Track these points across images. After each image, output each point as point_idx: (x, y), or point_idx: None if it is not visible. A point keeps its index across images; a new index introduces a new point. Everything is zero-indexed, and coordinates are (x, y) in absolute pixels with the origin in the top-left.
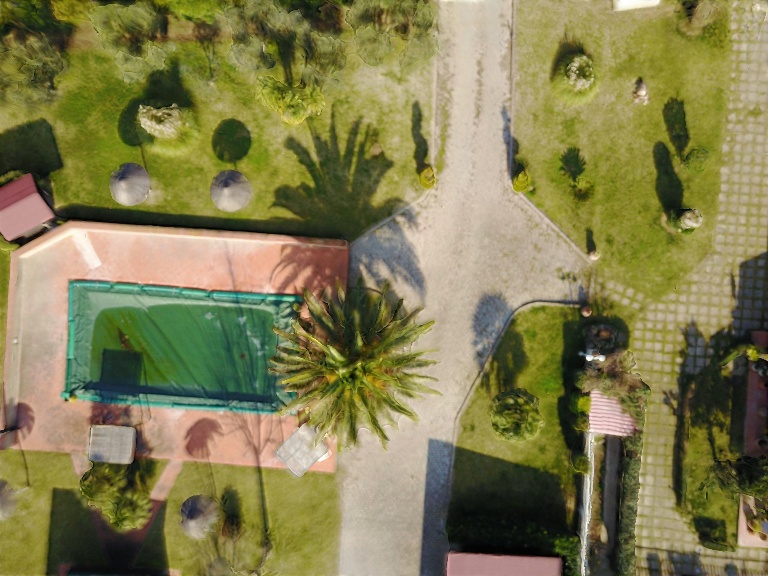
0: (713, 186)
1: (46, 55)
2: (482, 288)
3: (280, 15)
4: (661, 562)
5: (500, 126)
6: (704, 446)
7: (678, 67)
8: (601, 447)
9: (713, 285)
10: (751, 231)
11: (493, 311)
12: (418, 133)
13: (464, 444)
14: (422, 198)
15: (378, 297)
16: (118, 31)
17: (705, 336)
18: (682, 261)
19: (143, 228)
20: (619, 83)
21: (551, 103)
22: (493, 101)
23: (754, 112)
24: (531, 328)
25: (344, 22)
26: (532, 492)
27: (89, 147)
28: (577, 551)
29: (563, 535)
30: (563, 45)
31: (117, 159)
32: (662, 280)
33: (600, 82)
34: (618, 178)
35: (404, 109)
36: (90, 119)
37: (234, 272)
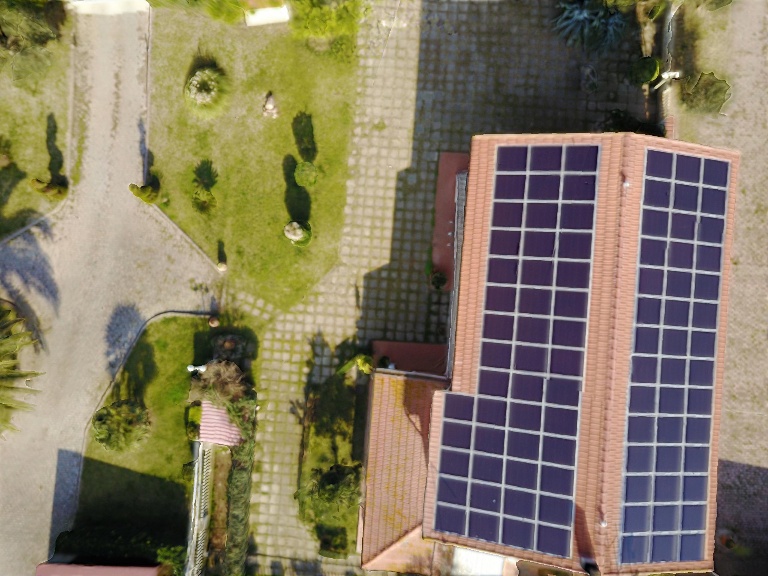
0: (339, 198)
1: None
2: (116, 299)
3: None
4: (284, 570)
5: (137, 138)
6: (328, 455)
7: (306, 81)
8: (229, 456)
9: (338, 296)
10: (375, 243)
11: (126, 321)
12: (53, 145)
13: (92, 454)
14: (57, 209)
15: (9, 308)
16: None
17: (331, 346)
18: (309, 272)
19: None
20: (250, 97)
21: (185, 116)
22: (130, 113)
23: (378, 126)
24: (162, 338)
25: None
26: (158, 502)
27: None
28: (180, 560)
29: (166, 544)
30: (197, 59)
31: None
32: (290, 291)
33: (230, 96)
34: (249, 190)
35: (39, 121)
36: None
37: None
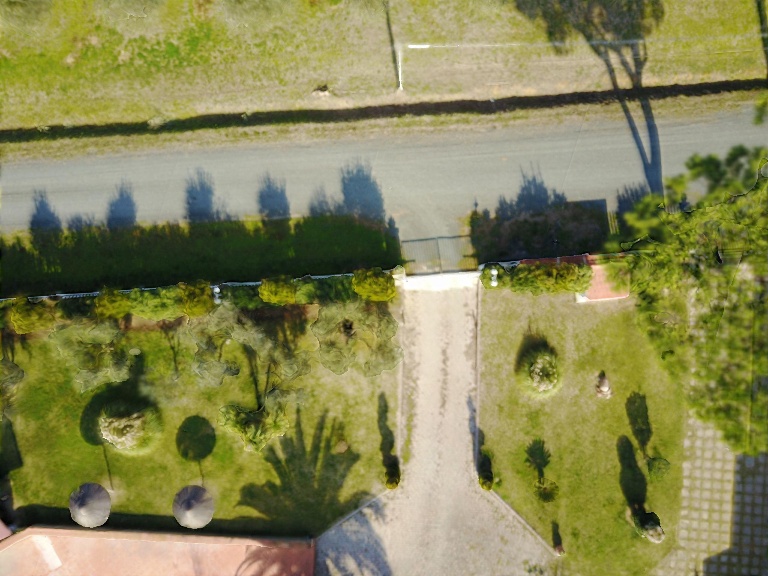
0: (676, 481)
1: (5, 375)
2: None
3: (244, 335)
4: None
5: (466, 416)
6: None
7: (640, 362)
8: None
9: None
10: (713, 526)
11: None
12: (384, 425)
13: None
14: (388, 490)
15: None
16: (80, 346)
17: None
18: (647, 556)
19: (104, 534)
20: (582, 376)
21: (516, 394)
22: (459, 390)
23: (714, 407)
24: None
25: (310, 313)
26: None
27: (50, 445)
28: None
29: None
30: (527, 337)
31: (79, 458)
32: (627, 574)
33: (564, 376)
34: (583, 471)
35: (370, 401)
36: (51, 416)
37: (198, 571)
